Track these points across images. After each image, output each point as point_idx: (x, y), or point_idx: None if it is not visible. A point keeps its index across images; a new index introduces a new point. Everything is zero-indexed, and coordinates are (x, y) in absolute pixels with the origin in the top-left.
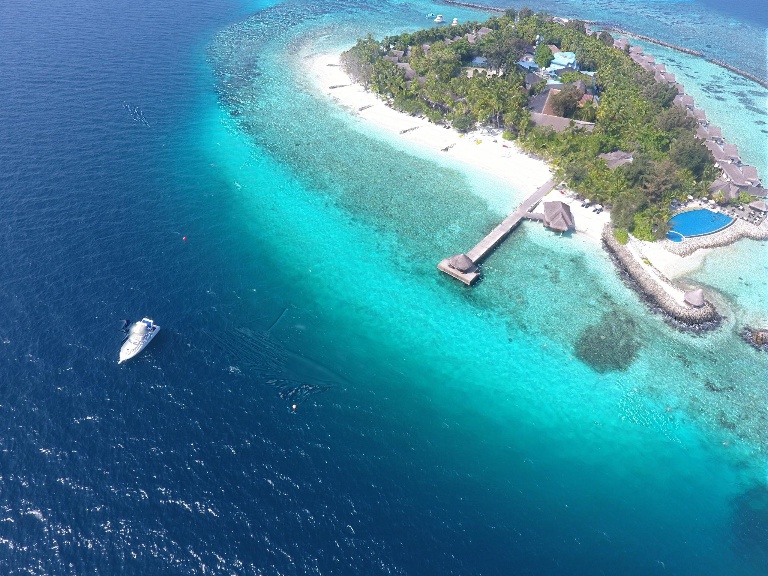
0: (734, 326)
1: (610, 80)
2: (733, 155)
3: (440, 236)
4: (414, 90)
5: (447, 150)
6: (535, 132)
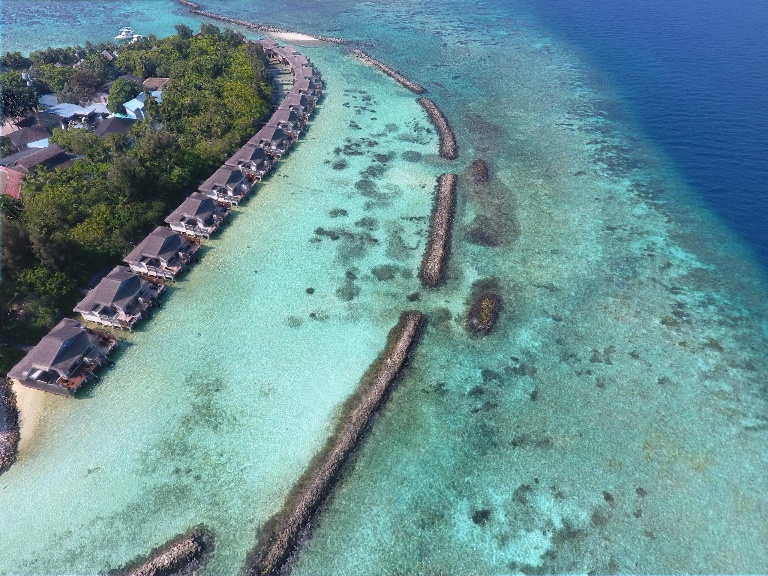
0: None
1: (110, 144)
2: (103, 302)
3: None
4: None
5: None
6: None
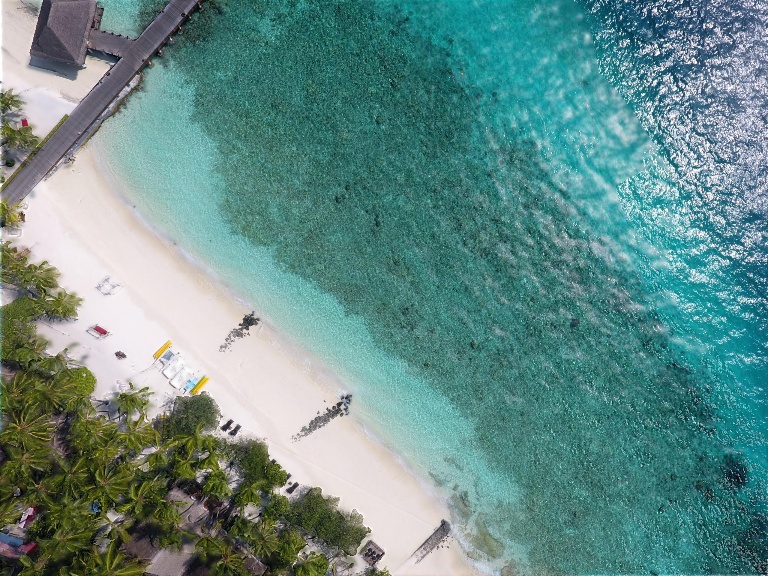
0: None
1: None
2: None
3: (299, 4)
4: (308, 562)
5: (245, 320)
6: (7, 338)
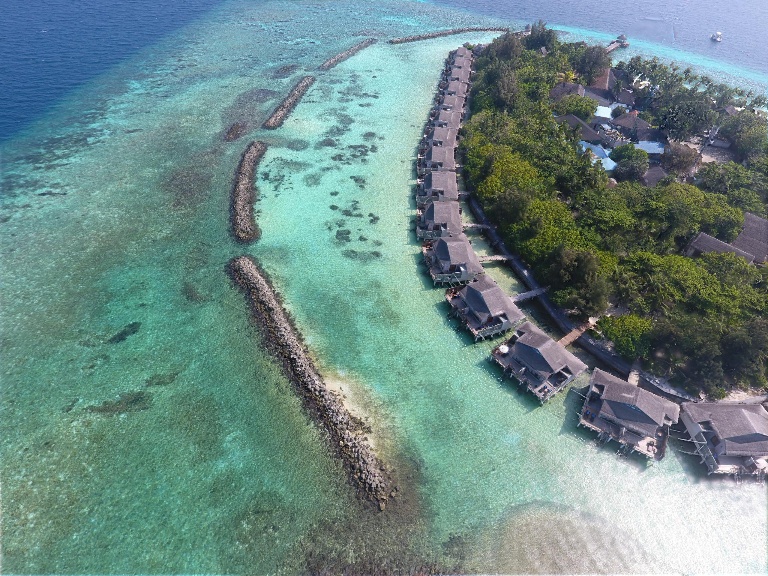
0: (510, 32)
1: None
2: None
3: None
4: None
5: None
6: None
